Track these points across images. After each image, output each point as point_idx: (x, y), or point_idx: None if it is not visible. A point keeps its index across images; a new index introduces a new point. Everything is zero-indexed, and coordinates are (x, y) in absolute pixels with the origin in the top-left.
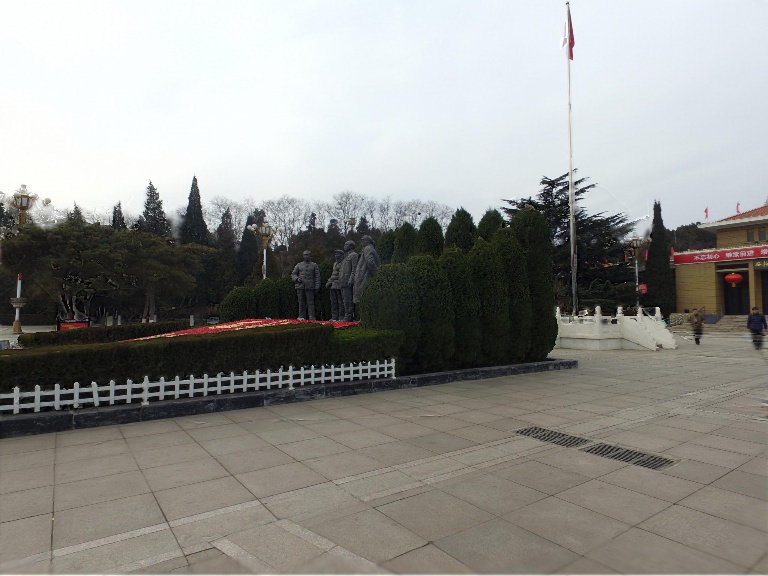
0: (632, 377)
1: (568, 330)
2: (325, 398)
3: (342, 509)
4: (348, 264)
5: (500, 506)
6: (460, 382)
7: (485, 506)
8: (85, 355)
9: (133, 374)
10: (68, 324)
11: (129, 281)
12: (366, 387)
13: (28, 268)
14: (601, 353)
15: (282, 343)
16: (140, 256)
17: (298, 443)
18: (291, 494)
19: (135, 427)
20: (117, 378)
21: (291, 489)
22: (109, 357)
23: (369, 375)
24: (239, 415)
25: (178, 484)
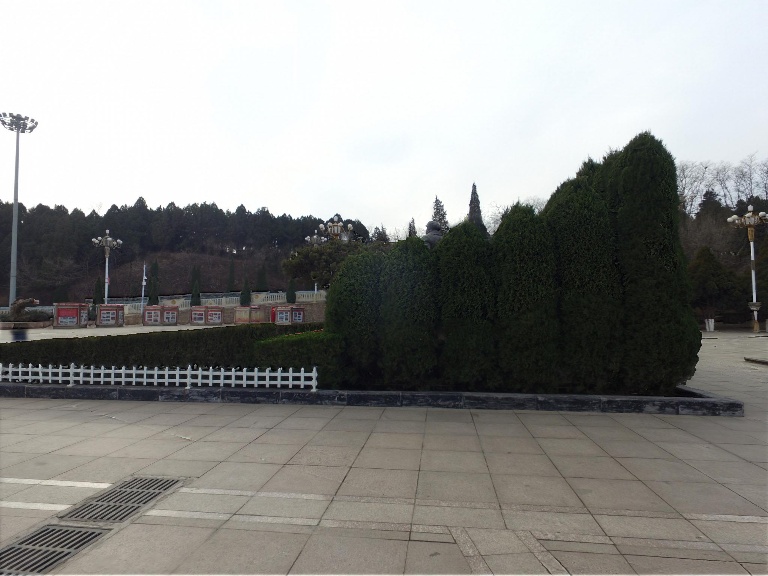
0: None
1: None
2: (220, 402)
3: None
4: None
5: None
6: (417, 408)
7: None
8: (48, 344)
9: (78, 361)
10: None
11: None
12: (272, 397)
13: None
14: None
15: (193, 342)
16: None
17: (10, 435)
18: None
19: (43, 402)
20: (70, 363)
21: None
22: None
23: (279, 384)
24: (112, 405)
25: None
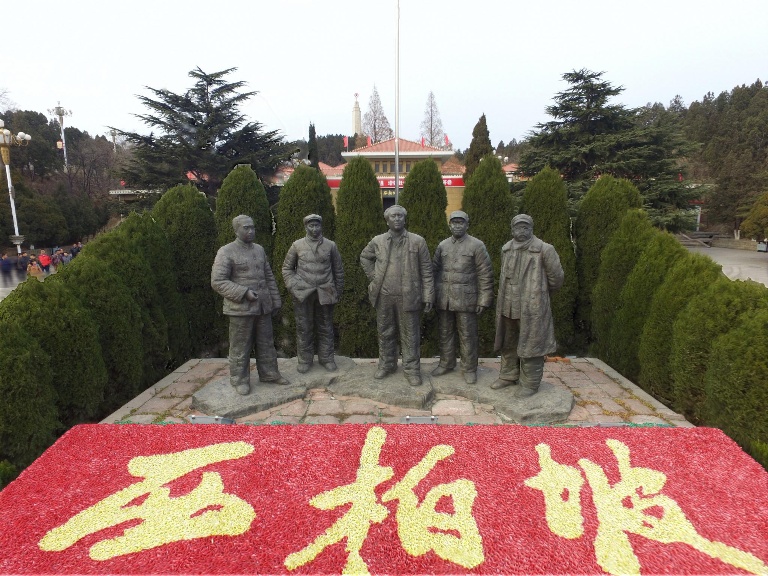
0: None
1: None
2: None
3: None
4: (415, 260)
5: None
6: None
7: None
8: None
9: None
10: None
11: None
12: None
13: None
14: None
15: None
16: None
17: None
18: None
19: None
20: None
21: None
22: None
23: None
24: None
25: None
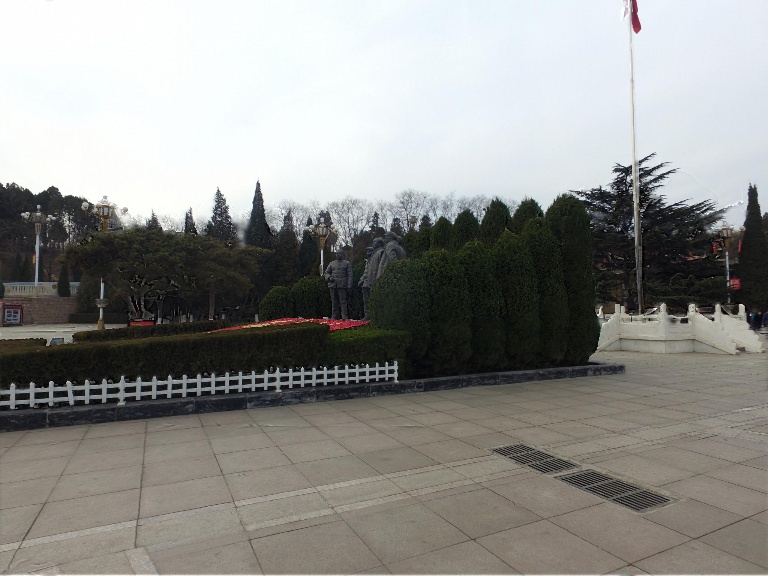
0: (684, 386)
1: (629, 330)
2: (316, 402)
3: (213, 539)
4: (376, 261)
5: (396, 550)
6: (475, 387)
7: (378, 548)
8: (64, 354)
9: (113, 374)
10: (137, 323)
11: (189, 282)
12: (363, 391)
13: (100, 271)
14: (665, 356)
15: (271, 344)
16: (200, 258)
17: (242, 453)
18: (177, 515)
19: (104, 427)
20: (98, 377)
21: (183, 509)
22: (88, 356)
23: (367, 378)
24: (214, 418)
25: (79, 495)
